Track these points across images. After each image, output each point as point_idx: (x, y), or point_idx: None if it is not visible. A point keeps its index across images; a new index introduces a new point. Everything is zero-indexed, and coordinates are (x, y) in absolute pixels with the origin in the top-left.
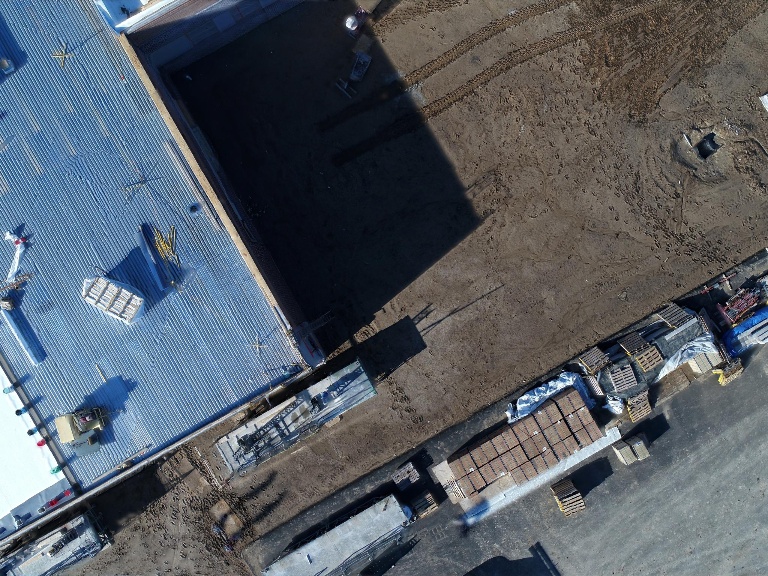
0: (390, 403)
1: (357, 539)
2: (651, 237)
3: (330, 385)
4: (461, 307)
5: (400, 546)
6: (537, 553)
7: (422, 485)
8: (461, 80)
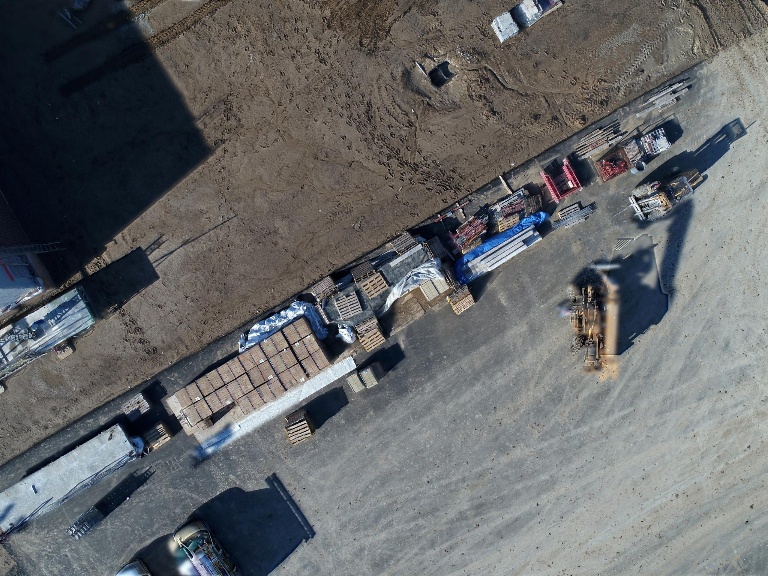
0: (123, 335)
1: (83, 469)
2: (385, 166)
3: (48, 313)
4: (193, 238)
5: (135, 478)
6: (273, 484)
7: (156, 417)
8: (188, 10)
